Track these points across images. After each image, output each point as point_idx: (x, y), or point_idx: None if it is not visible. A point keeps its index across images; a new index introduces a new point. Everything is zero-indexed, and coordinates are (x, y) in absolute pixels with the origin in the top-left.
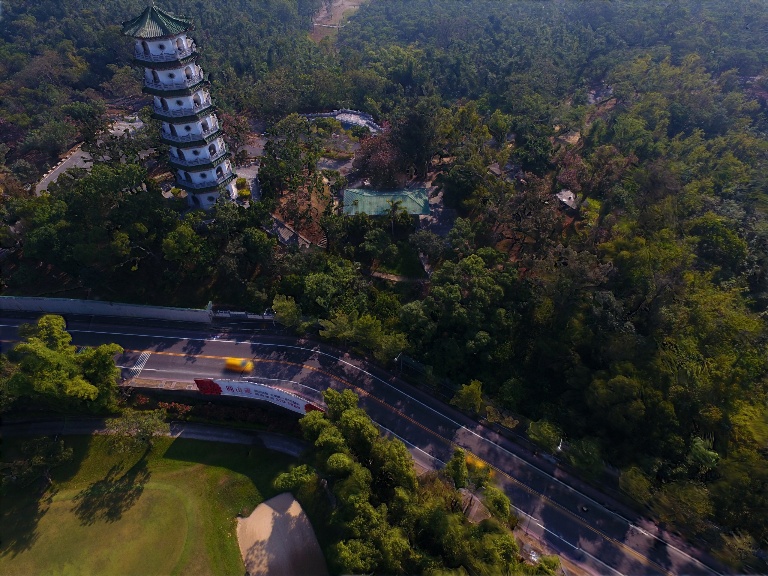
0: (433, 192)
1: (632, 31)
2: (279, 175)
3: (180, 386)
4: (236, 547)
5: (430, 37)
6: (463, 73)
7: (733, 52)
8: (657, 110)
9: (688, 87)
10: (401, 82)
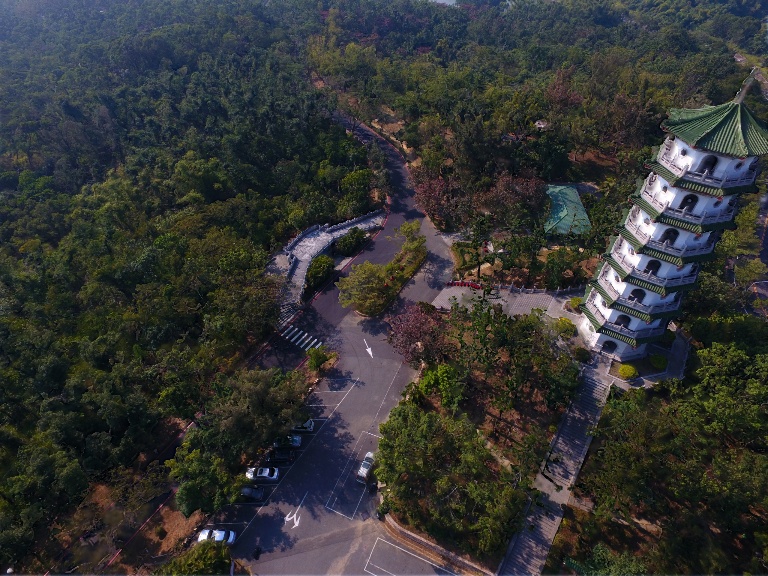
0: (549, 177)
1: (228, 46)
2: None
3: None
4: None
5: (4, 174)
6: (254, 141)
7: (307, 28)
8: (404, 70)
9: (364, 54)
10: (220, 195)
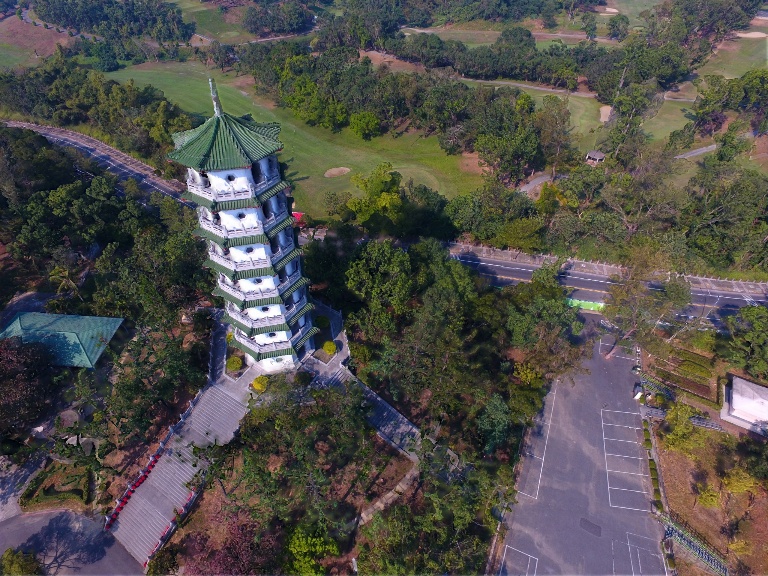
0: None
1: None
2: (174, 313)
3: (323, 234)
4: (295, 198)
5: None
6: None
7: None
8: None
9: None
10: None
